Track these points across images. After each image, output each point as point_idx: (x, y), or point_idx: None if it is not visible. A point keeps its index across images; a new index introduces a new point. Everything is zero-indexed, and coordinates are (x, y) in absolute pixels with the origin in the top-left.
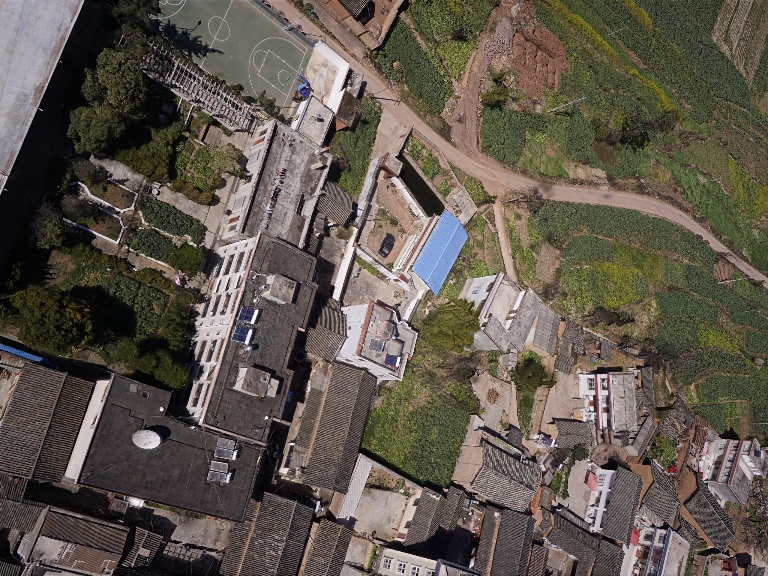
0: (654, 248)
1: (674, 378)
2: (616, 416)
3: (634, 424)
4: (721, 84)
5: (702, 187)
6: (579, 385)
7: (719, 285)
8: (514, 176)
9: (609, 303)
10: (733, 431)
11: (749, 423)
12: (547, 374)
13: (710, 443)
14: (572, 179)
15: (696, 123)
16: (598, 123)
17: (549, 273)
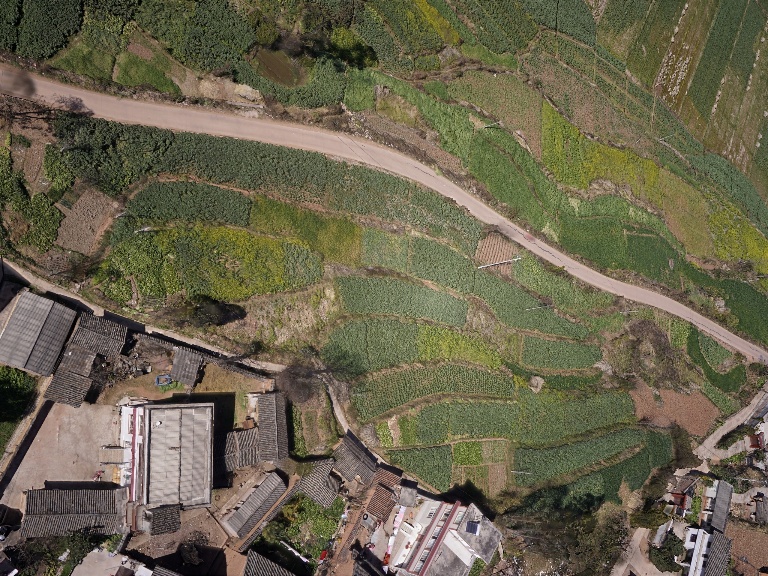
0: (352, 211)
1: (351, 408)
2: (156, 480)
3: (205, 491)
4: (547, 8)
5: (476, 133)
6: (121, 424)
7: (479, 270)
8: (20, 75)
9: (221, 290)
10: (472, 485)
11: (507, 471)
12: (35, 407)
13: (419, 506)
14: (172, 93)
15: (490, 51)
16: (255, 17)
17: (93, 238)
